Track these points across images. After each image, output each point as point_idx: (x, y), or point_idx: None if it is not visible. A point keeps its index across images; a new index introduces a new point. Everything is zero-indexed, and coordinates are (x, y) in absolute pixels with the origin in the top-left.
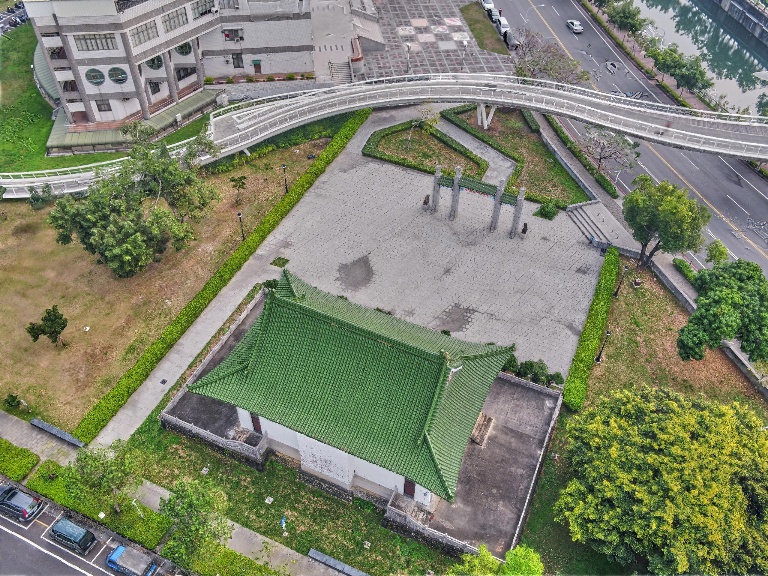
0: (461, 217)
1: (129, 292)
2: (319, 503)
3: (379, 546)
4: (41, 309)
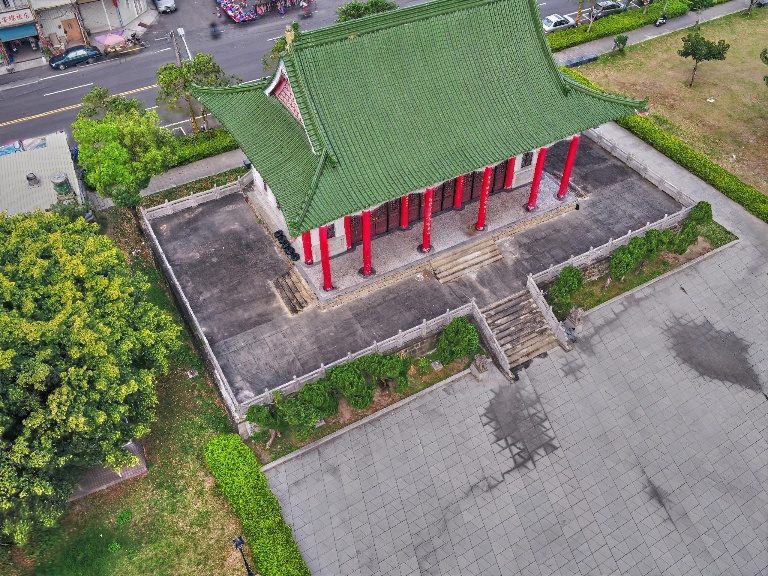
0: None
1: (765, 135)
2: None
3: None
4: (760, 82)
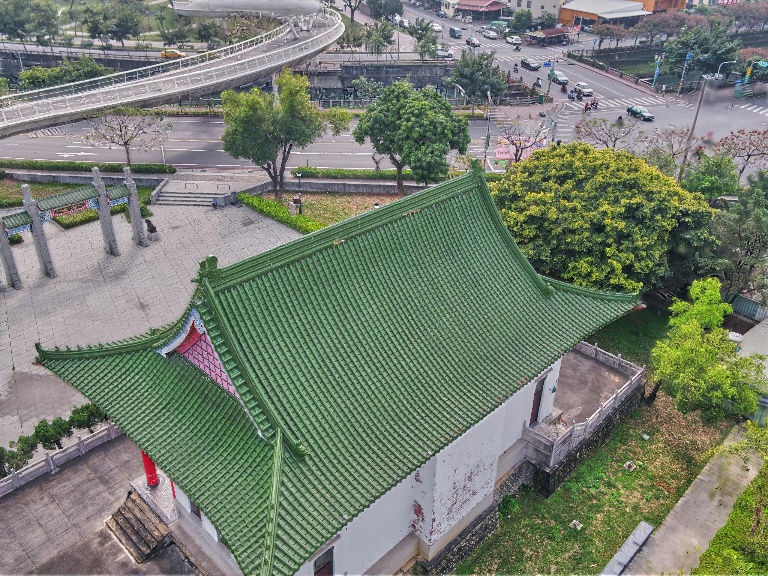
0: (61, 268)
1: None
2: (485, 572)
3: (580, 511)
4: None
